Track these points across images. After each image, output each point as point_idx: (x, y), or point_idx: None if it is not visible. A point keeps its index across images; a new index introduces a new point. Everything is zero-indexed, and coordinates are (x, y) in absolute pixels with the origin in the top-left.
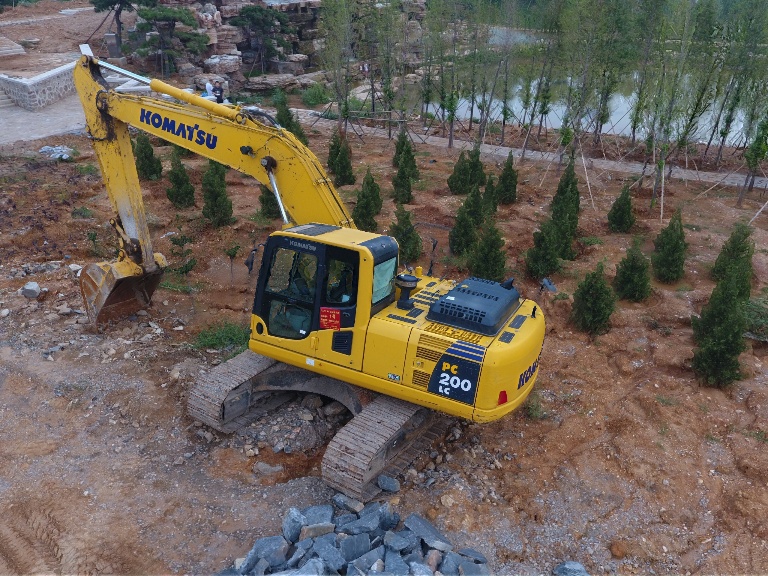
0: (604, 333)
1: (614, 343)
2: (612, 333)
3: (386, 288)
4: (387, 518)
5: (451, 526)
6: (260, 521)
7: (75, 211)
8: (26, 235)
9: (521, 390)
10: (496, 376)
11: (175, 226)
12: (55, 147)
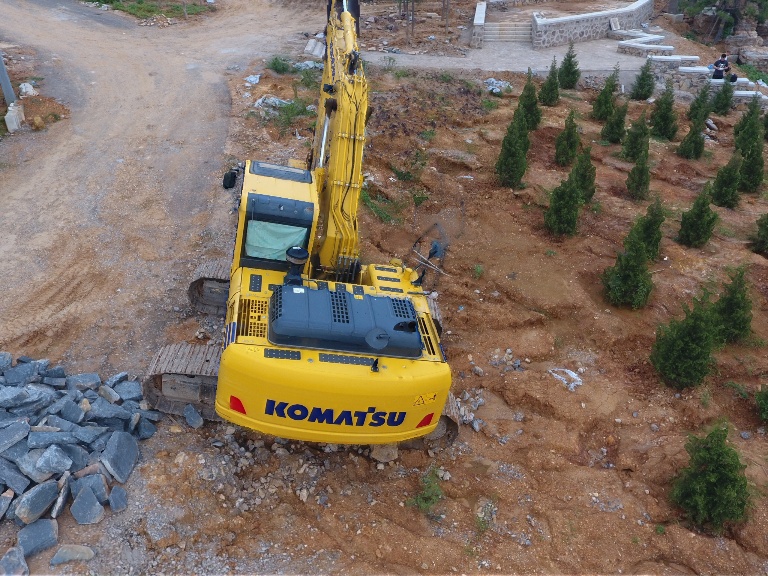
0: (709, 535)
1: (688, 551)
2: (708, 540)
3: (281, 252)
4: (131, 424)
5: (143, 469)
6: (126, 370)
7: (424, 132)
8: (376, 137)
9: (282, 421)
10: (225, 374)
11: (480, 172)
12: (499, 81)
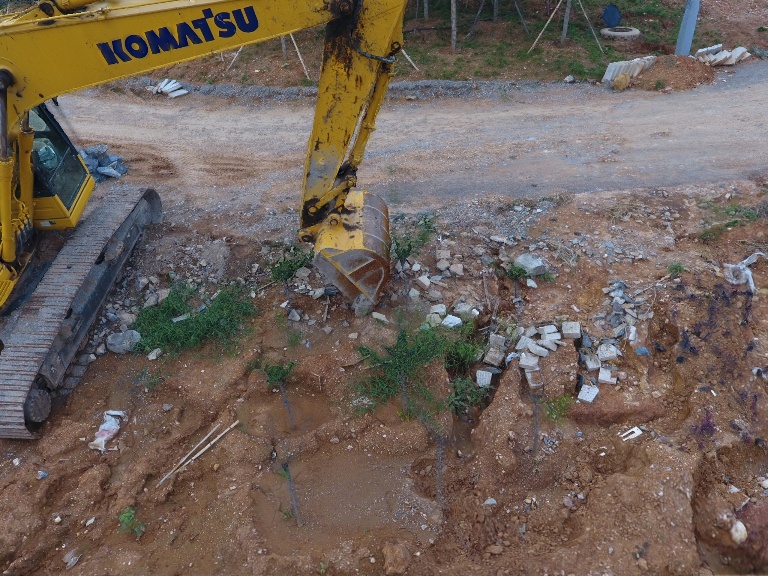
0: None
1: None
2: None
3: None
4: None
5: None
6: None
7: None
8: None
9: None
10: None
11: None
12: None
